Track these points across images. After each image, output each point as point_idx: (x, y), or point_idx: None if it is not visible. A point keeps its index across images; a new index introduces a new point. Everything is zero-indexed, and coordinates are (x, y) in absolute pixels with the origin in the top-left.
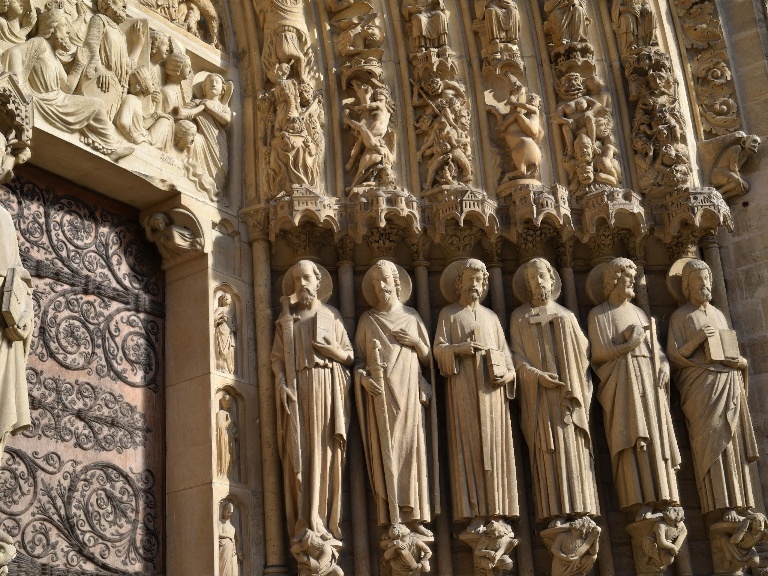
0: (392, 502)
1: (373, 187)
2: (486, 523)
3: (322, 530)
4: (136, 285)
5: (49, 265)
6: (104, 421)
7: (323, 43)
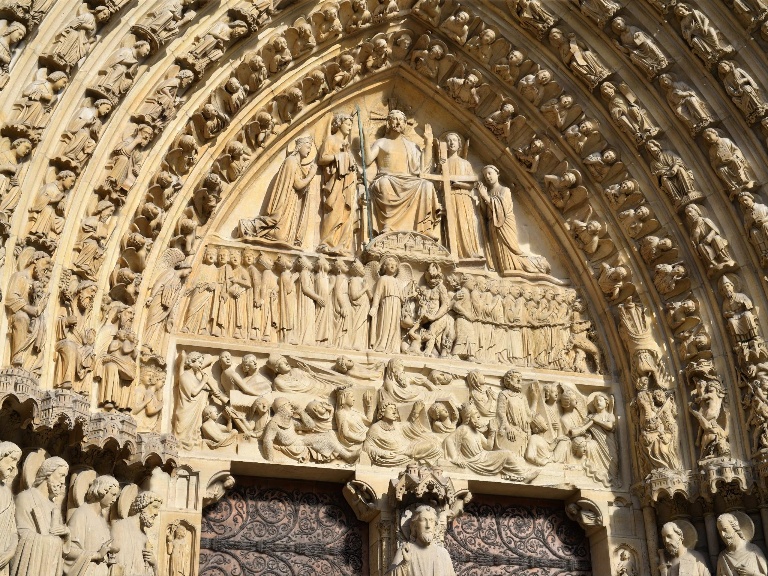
0: None
1: (711, 460)
2: None
3: None
4: (568, 553)
5: (502, 556)
6: None
7: (671, 352)
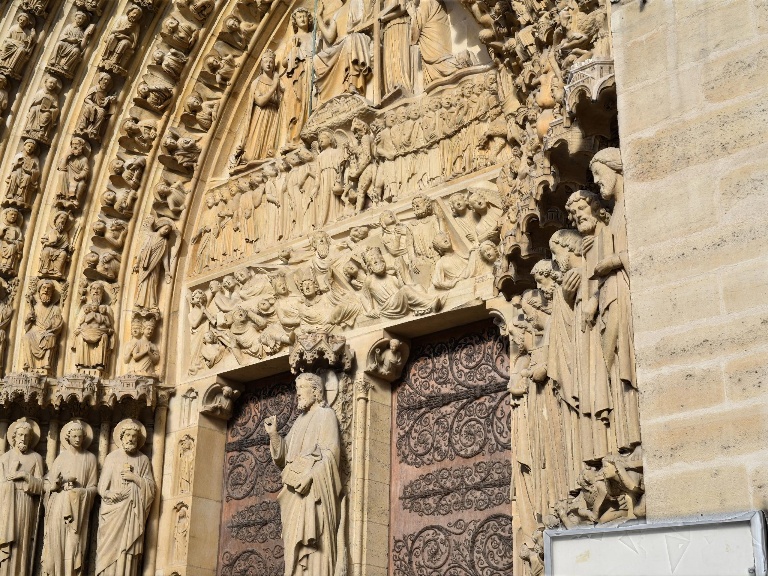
0: None
1: None
2: None
3: None
4: None
5: (451, 393)
6: (494, 485)
7: None
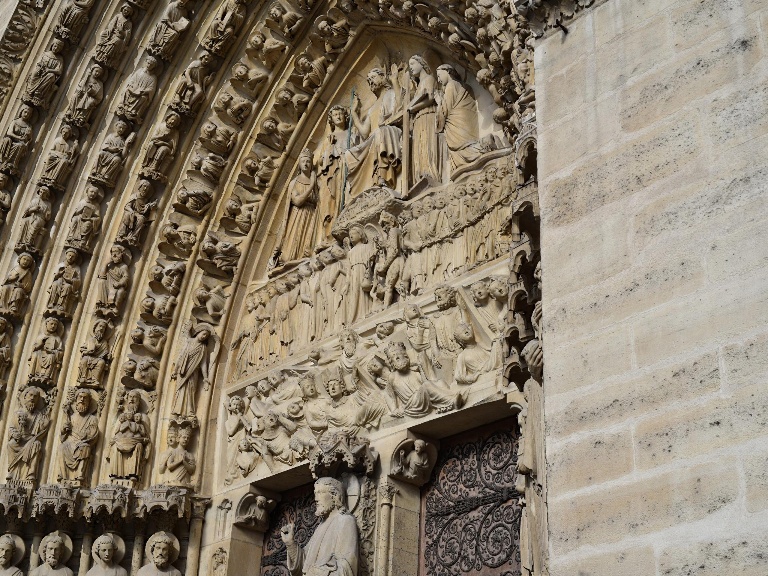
0: None
1: None
2: None
3: None
4: None
5: (478, 497)
6: None
7: None
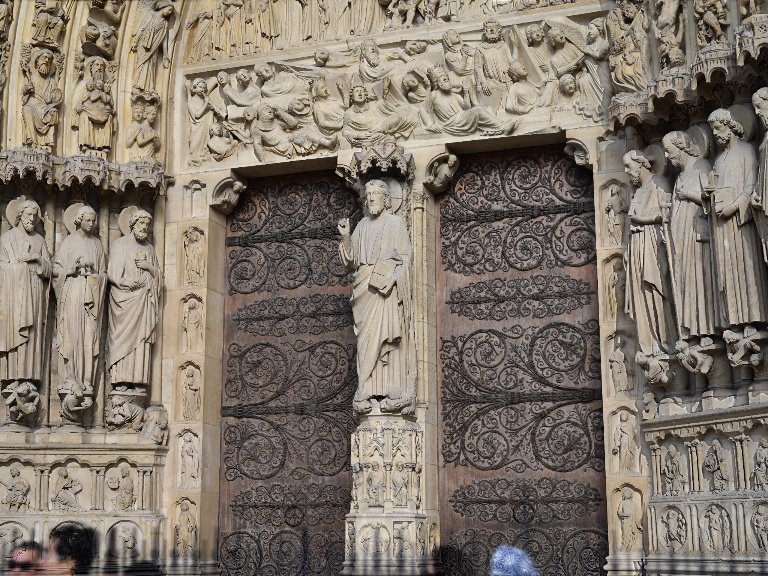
0: (677, 325)
1: None
2: (738, 330)
3: (655, 350)
4: (577, 196)
5: (504, 210)
6: (554, 296)
7: None
